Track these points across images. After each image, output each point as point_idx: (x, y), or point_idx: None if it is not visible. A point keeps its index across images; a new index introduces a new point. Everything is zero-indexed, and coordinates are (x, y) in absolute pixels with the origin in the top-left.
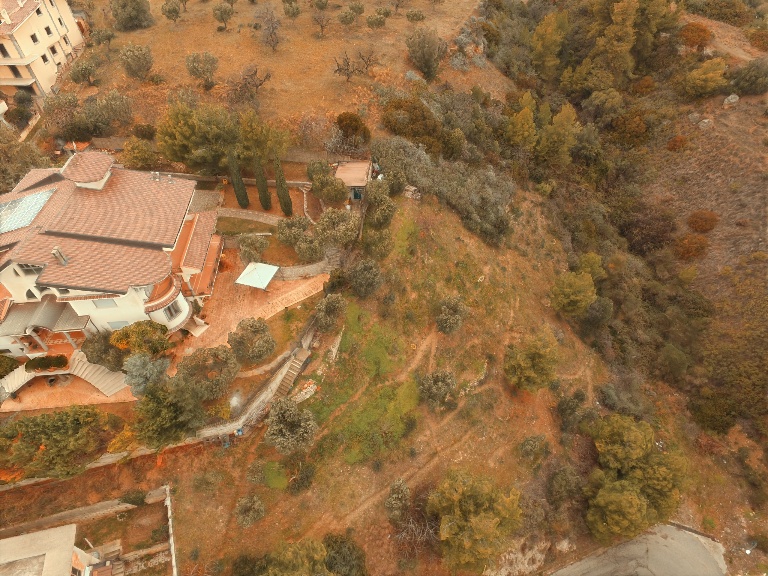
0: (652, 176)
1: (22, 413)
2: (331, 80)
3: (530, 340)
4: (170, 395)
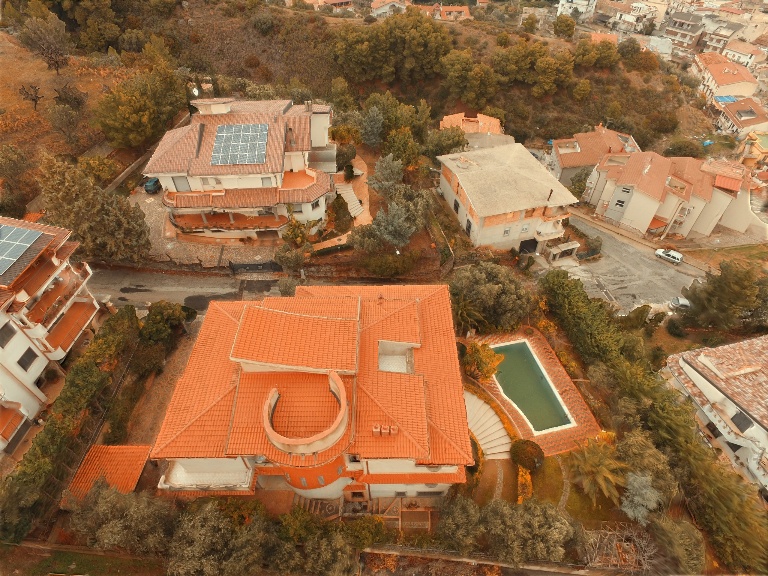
0: (208, 59)
1: (371, 201)
2: (47, 81)
3: (340, 86)
4: (388, 110)
